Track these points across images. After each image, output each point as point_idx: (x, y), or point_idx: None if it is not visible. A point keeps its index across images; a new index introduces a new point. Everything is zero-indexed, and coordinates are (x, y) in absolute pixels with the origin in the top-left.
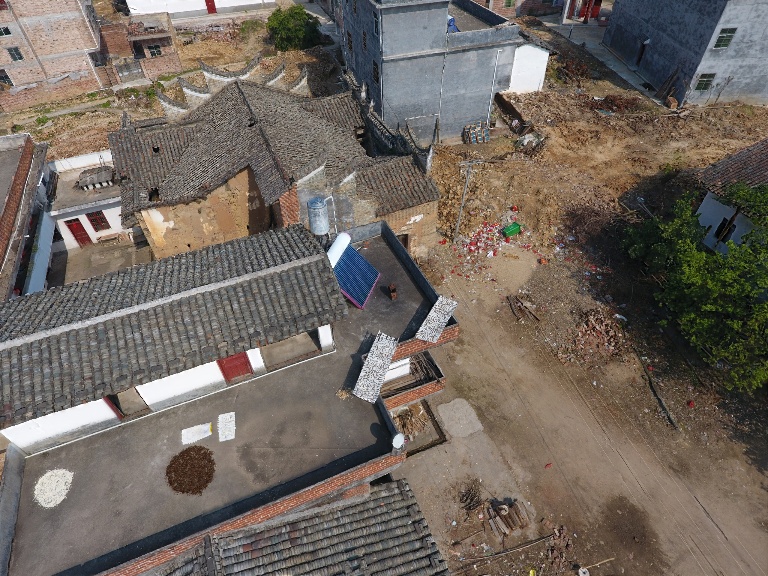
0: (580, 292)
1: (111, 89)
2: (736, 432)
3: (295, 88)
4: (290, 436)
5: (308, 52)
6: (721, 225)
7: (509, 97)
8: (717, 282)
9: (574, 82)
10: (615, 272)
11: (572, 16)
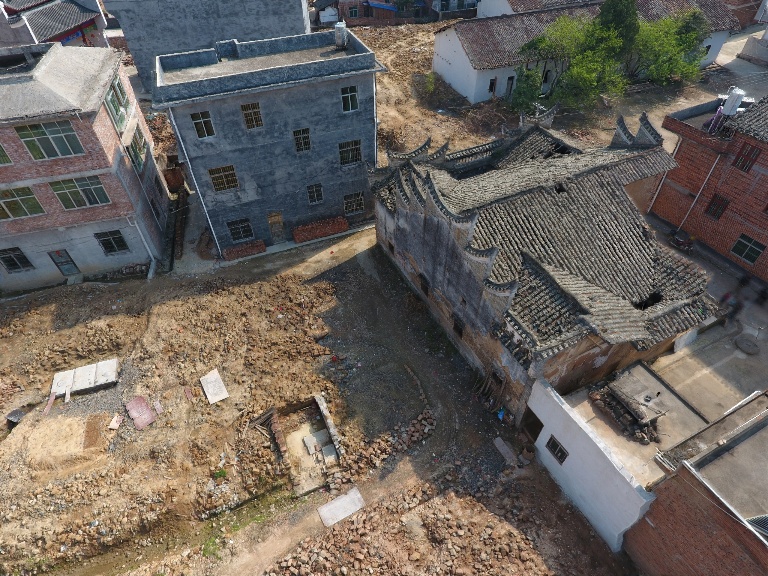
0: None
1: None
2: None
3: None
4: None
5: None
6: None
7: None
8: None
9: None
10: None
11: None
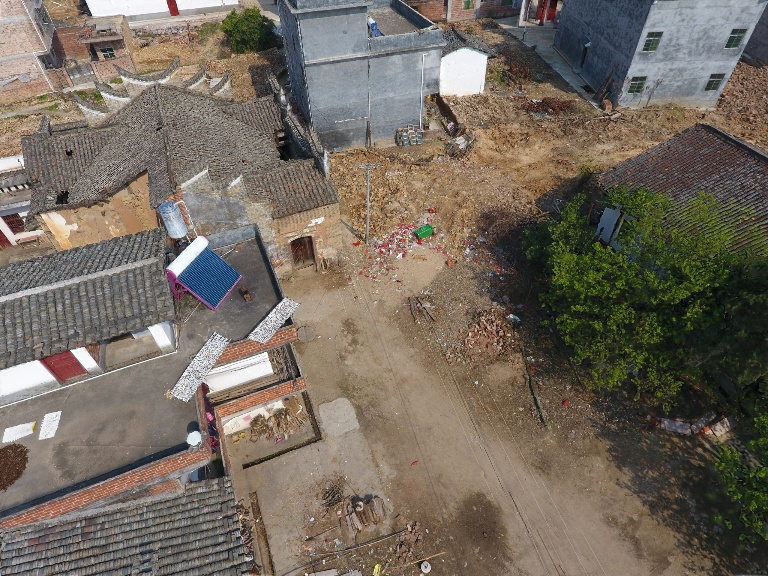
0: (479, 293)
1: (62, 92)
2: (603, 430)
3: (219, 92)
4: (108, 434)
5: (261, 54)
6: (622, 227)
7: (449, 100)
8: (583, 283)
9: (516, 85)
10: (518, 273)
11: (529, 18)
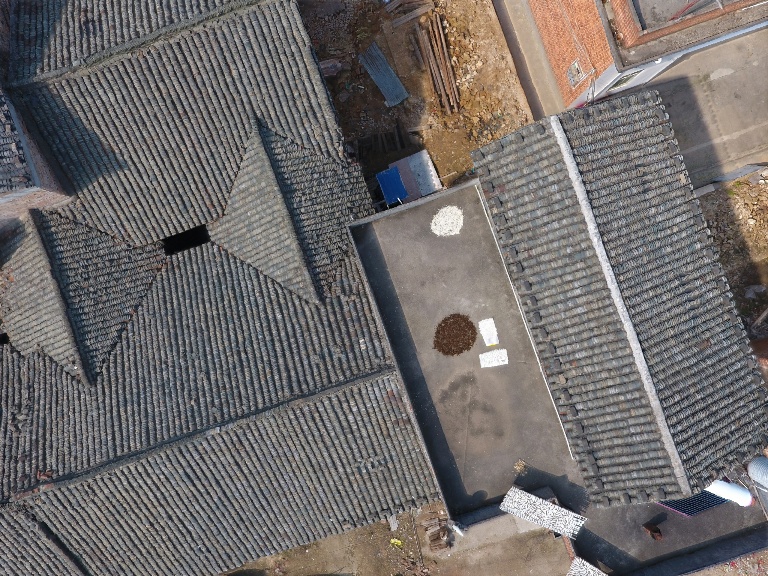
0: None
1: None
2: None
3: None
4: (480, 418)
5: None
6: None
7: None
8: None
9: None
10: None
11: None
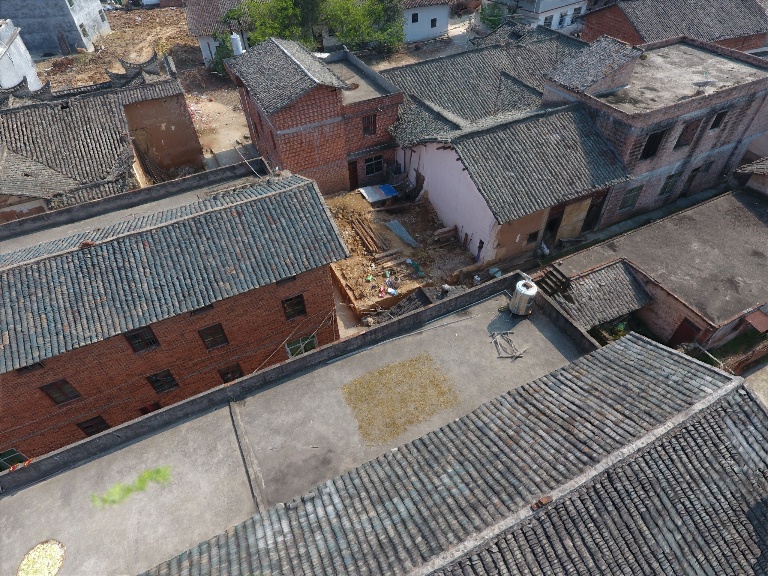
0: None
1: None
2: None
3: None
4: None
5: None
6: None
7: None
8: None
9: None
10: None
11: None
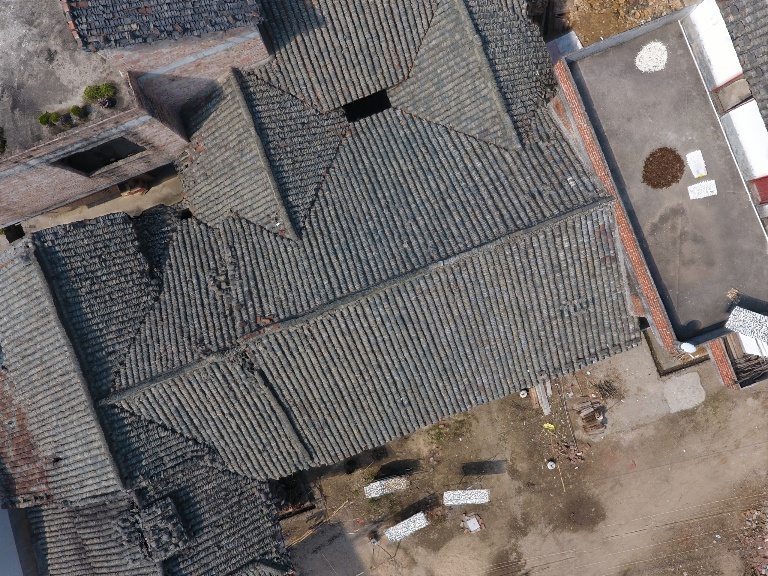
0: None
1: None
2: None
3: None
4: (691, 249)
5: None
6: None
7: None
8: None
9: None
10: None
11: None
